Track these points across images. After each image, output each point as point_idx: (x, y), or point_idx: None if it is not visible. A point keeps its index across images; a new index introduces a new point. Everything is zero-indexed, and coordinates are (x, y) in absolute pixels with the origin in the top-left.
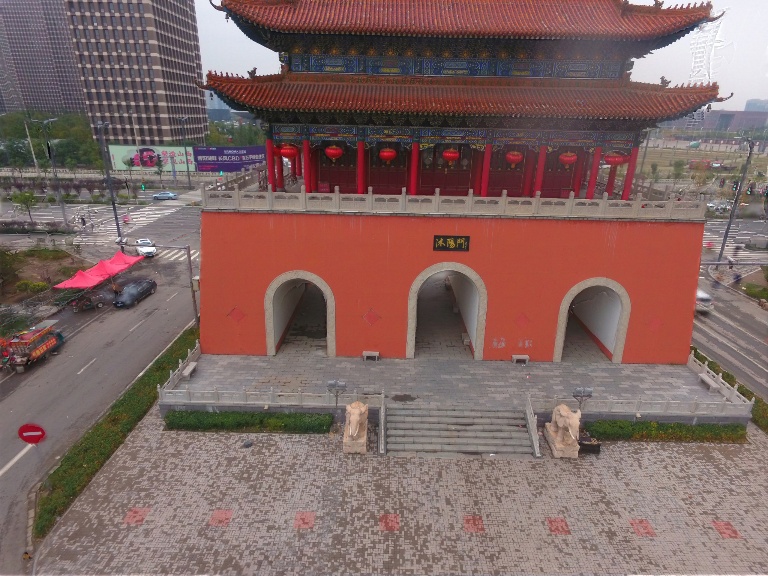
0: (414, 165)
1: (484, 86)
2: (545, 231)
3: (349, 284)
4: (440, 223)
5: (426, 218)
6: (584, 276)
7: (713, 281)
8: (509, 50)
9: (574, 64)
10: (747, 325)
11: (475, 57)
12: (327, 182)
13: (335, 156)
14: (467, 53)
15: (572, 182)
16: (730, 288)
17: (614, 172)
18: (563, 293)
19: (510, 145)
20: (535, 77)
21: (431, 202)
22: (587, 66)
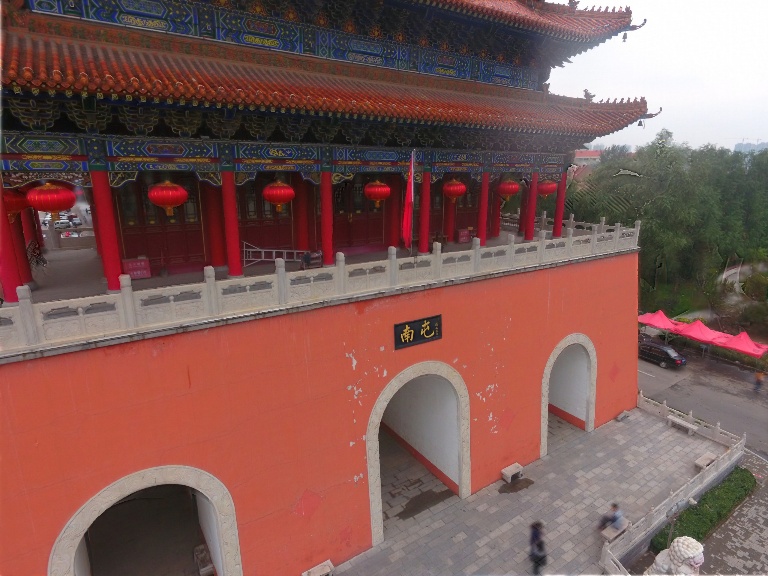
0: None
1: None
2: None
3: None
4: None
5: None
6: None
7: None
8: None
9: None
10: None
11: None
12: None
13: None
14: None
15: None
16: None
17: None
18: None
19: None
20: None
21: None
22: None
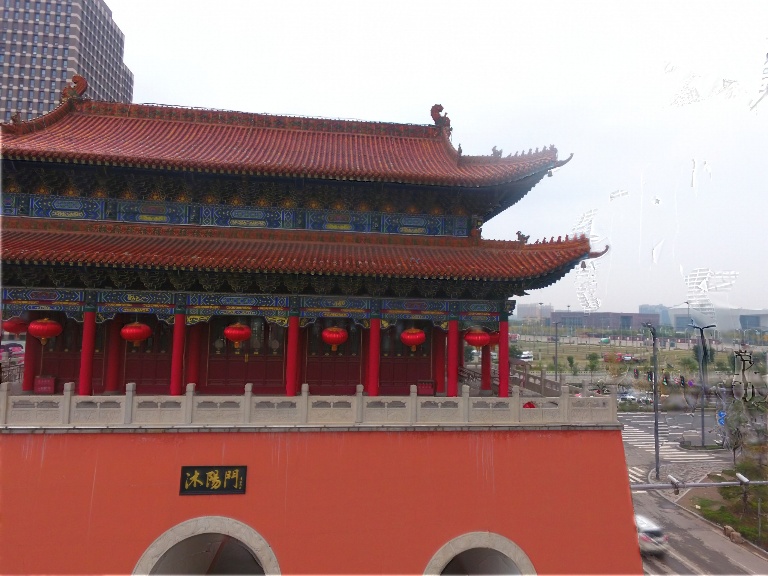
0: (175, 348)
1: (287, 241)
2: (377, 452)
3: (5, 574)
4: (193, 443)
5: (168, 435)
6: (452, 530)
7: (658, 497)
8: (319, 198)
9: (408, 218)
10: (723, 575)
11: (274, 206)
12: (51, 376)
13: (42, 334)
14: (264, 201)
15: (432, 371)
16: (681, 507)
17: (487, 357)
18: (420, 566)
19: (326, 318)
20: (357, 231)
21: (179, 407)
22: (425, 221)
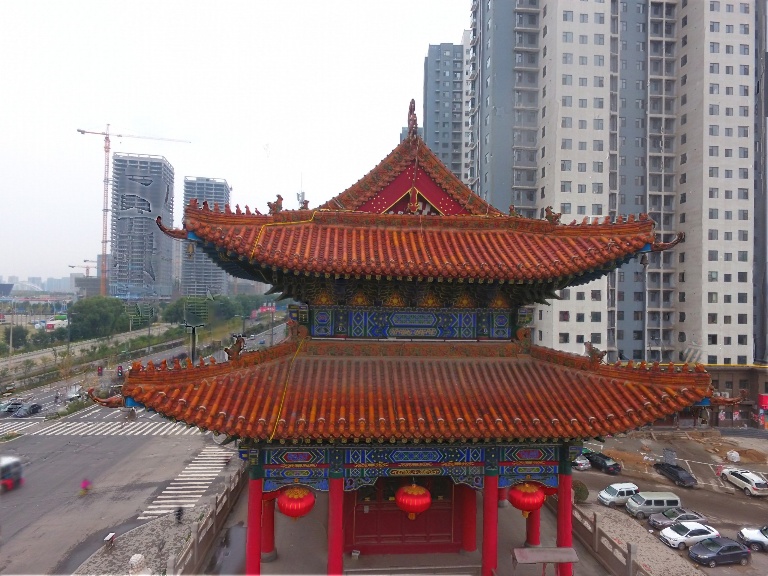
0: None
1: None
2: None
3: None
4: None
5: None
6: None
7: None
8: None
9: None
10: None
11: None
12: None
13: None
14: None
15: None
16: None
17: None
18: None
19: None
20: None
21: None
22: None
